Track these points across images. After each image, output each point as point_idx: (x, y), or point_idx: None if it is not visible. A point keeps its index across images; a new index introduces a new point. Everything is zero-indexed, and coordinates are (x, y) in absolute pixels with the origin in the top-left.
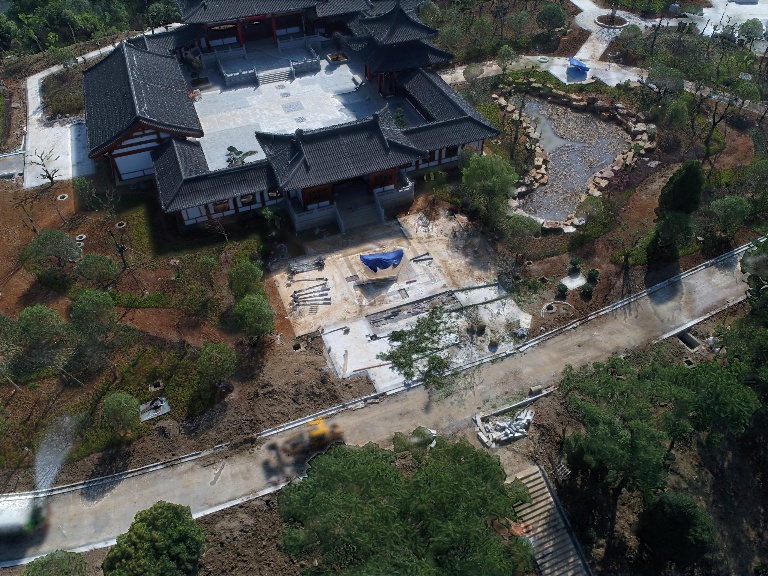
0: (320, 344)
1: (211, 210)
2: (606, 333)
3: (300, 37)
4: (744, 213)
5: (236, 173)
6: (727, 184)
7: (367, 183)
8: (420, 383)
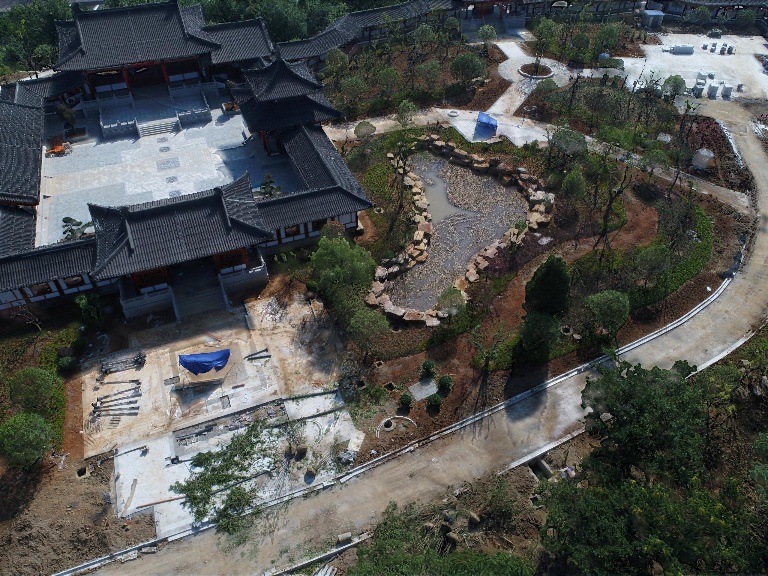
0: (109, 469)
1: (28, 293)
2: (446, 459)
3: (194, 84)
4: (621, 312)
5: (56, 252)
6: (615, 271)
7: (213, 263)
8: (212, 525)
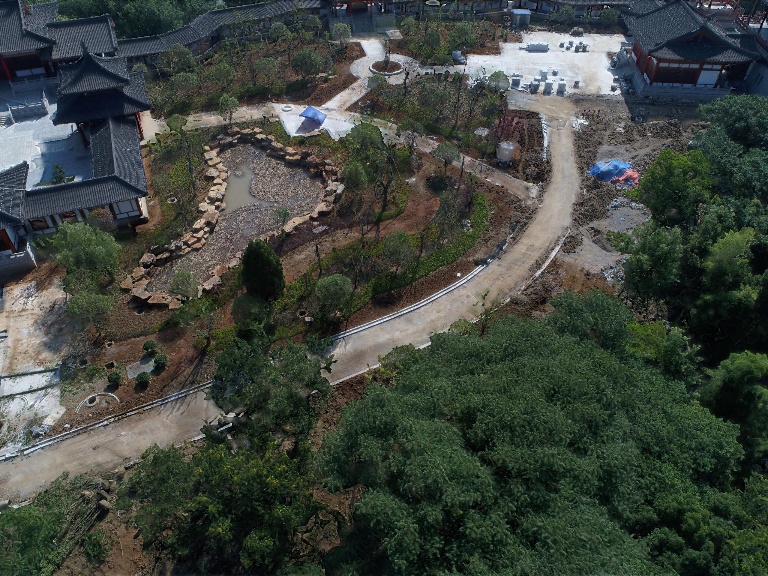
0: None
1: None
2: (135, 433)
3: (36, 79)
4: (338, 295)
5: None
6: (364, 257)
7: None
8: None
